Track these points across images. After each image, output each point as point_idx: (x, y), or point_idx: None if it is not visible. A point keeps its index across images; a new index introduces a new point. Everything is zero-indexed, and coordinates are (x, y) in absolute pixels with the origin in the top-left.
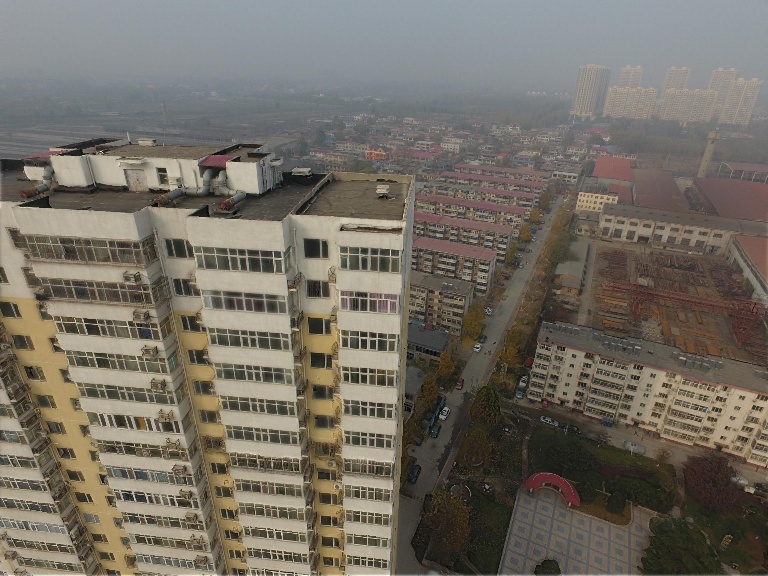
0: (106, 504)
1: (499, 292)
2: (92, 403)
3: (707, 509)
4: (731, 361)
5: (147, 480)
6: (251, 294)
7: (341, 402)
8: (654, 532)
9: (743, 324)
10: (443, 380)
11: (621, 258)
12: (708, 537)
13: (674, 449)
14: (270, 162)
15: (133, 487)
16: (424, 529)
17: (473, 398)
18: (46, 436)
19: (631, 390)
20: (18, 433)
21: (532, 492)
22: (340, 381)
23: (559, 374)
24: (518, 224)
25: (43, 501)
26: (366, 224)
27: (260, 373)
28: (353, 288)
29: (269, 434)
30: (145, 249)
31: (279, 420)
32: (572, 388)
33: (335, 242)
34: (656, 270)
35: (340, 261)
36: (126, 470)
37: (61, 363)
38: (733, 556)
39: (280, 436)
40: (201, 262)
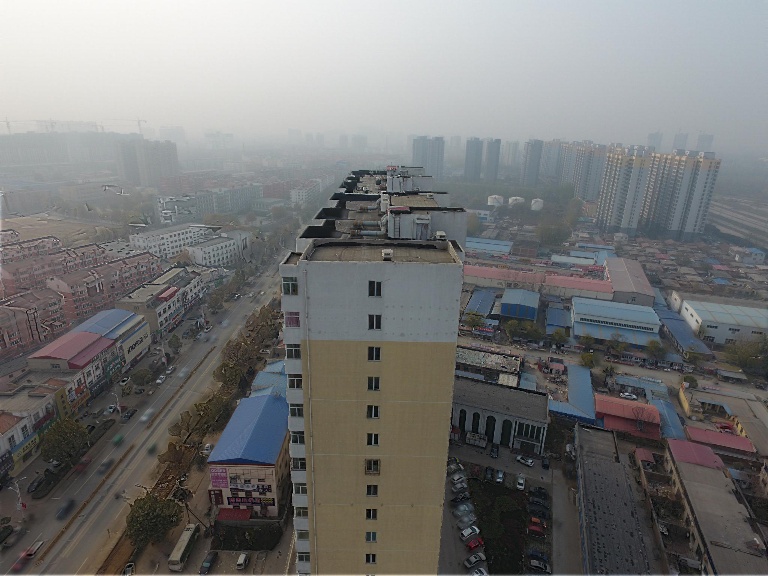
0: None
1: None
2: None
3: None
4: None
5: None
6: None
7: None
8: None
9: None
10: None
11: None
12: None
13: None
14: (416, 219)
15: None
16: None
17: None
18: None
19: None
20: None
21: None
22: None
23: None
24: None
25: None
26: None
27: None
28: None
29: None
30: None
31: None
32: None
33: None
34: None
35: None
36: None
37: None
38: None
39: None
40: None
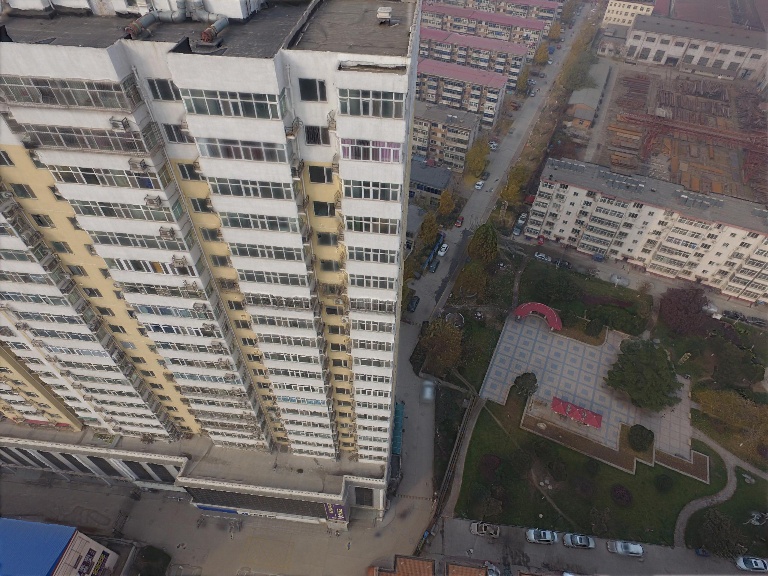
0: (138, 334)
1: (506, 124)
2: (106, 249)
3: (674, 332)
4: (732, 199)
5: (172, 315)
6: (248, 142)
7: (345, 249)
8: (623, 351)
9: (755, 159)
10: (443, 218)
11: (643, 84)
12: (670, 354)
13: (656, 282)
14: None
15: (160, 321)
16: (421, 349)
17: (471, 235)
18: (70, 278)
19: (627, 228)
20: (43, 276)
21: (519, 319)
22: (344, 229)
23: (558, 212)
24: (535, 42)
25: (82, 332)
26: (367, 61)
27: (265, 222)
28: (354, 135)
29: (279, 277)
30: (127, 91)
31: (287, 265)
32: (569, 226)
33: (333, 83)
34: (678, 98)
35: (340, 105)
36: (151, 307)
37: (67, 211)
38: (688, 369)
39: (289, 279)
40: (190, 106)
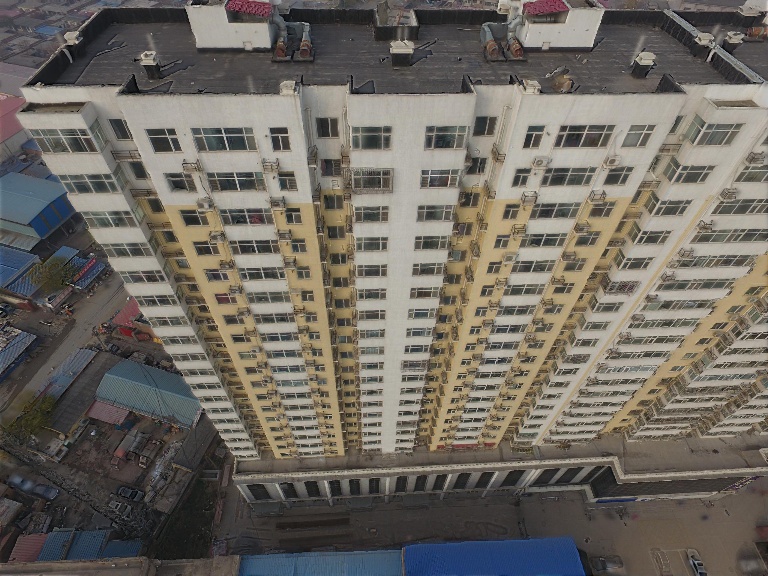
0: (694, 344)
1: None
2: None
3: None
4: None
5: None
6: None
7: None
8: None
9: None
10: None
11: None
12: None
13: None
14: None
15: None
16: None
17: None
18: None
19: None
20: (712, 300)
21: None
22: None
23: None
24: None
25: None
26: None
27: None
28: None
29: None
30: None
31: None
32: None
33: None
34: None
35: None
36: None
37: None
38: None
39: None
40: None
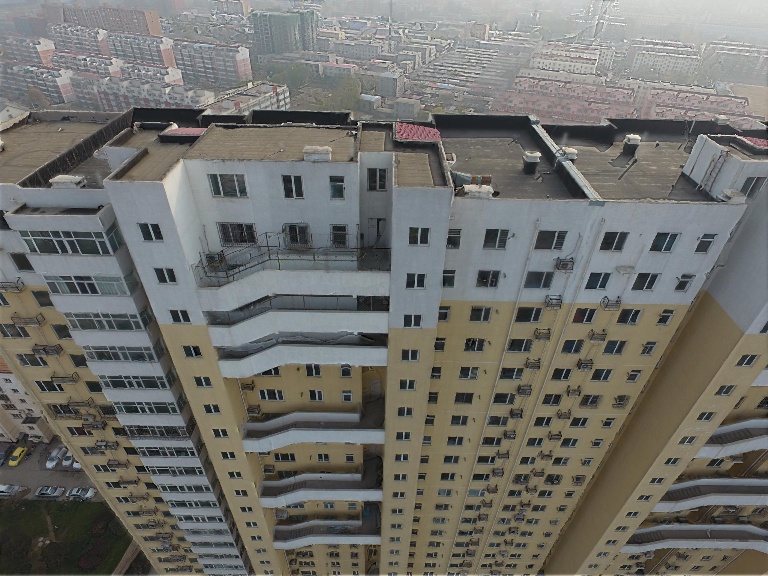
0: None
1: None
2: None
3: None
4: None
5: None
6: None
7: None
8: None
9: None
10: None
11: None
12: None
13: None
14: None
15: None
16: None
17: None
18: None
19: None
20: None
21: None
22: None
23: None
24: None
25: None
26: None
27: None
28: None
29: None
30: None
31: None
32: None
33: None
34: None
35: None
36: None
37: None
38: None
39: None
40: None
